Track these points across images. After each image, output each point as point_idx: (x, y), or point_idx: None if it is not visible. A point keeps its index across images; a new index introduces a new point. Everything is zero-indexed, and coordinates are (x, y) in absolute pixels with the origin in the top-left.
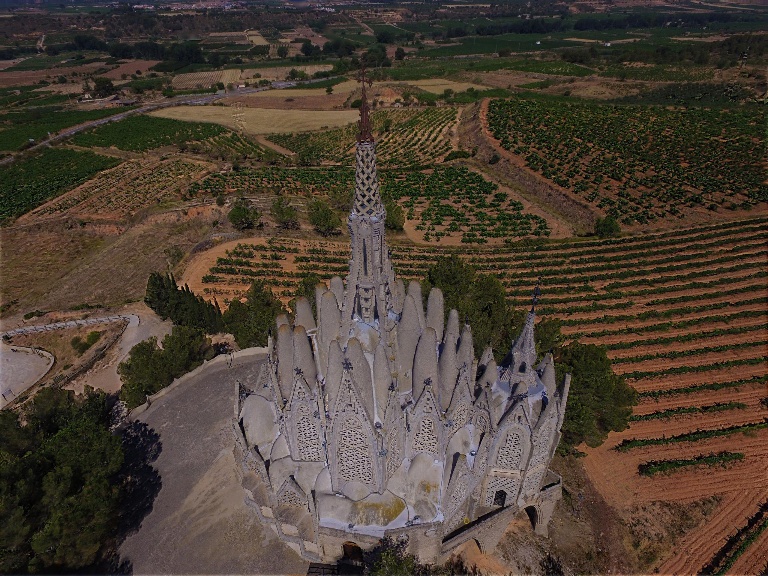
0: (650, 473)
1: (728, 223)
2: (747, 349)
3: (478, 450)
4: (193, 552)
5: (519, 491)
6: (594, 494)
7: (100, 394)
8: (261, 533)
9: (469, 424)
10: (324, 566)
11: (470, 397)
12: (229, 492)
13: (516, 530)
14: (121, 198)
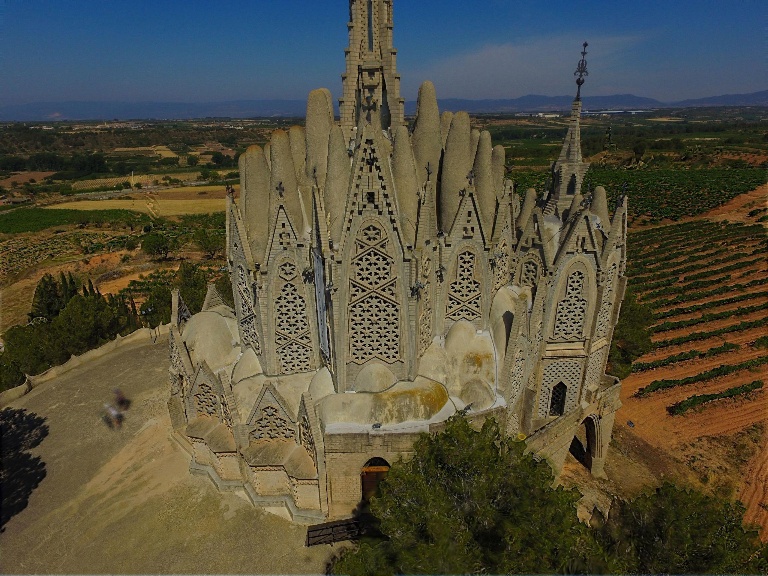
0: (683, 409)
1: (647, 230)
2: (712, 309)
3: (533, 305)
4: (102, 548)
5: (583, 379)
6: (634, 438)
7: None
8: (221, 503)
9: (510, 286)
10: (332, 524)
11: (511, 237)
12: (162, 464)
13: (569, 474)
14: (2, 263)
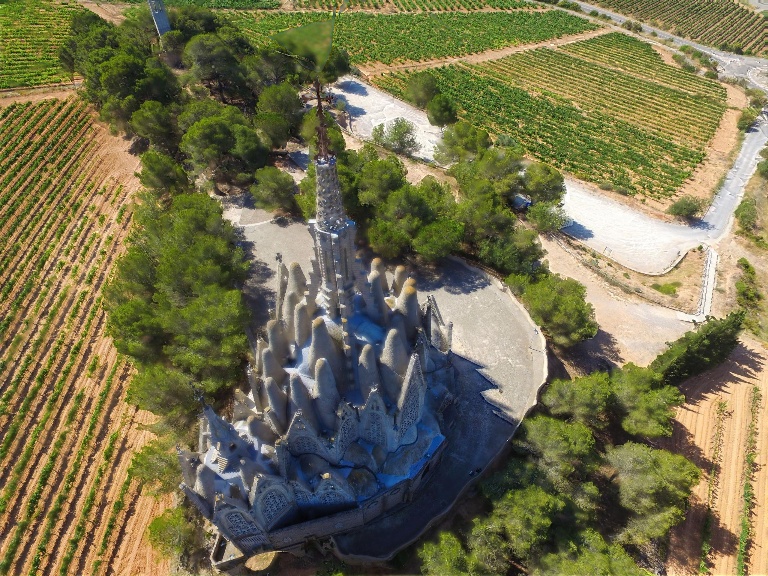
0: None
1: None
2: None
3: None
4: None
5: None
6: None
7: (545, 274)
8: None
9: None
10: None
11: None
12: None
13: None
14: None
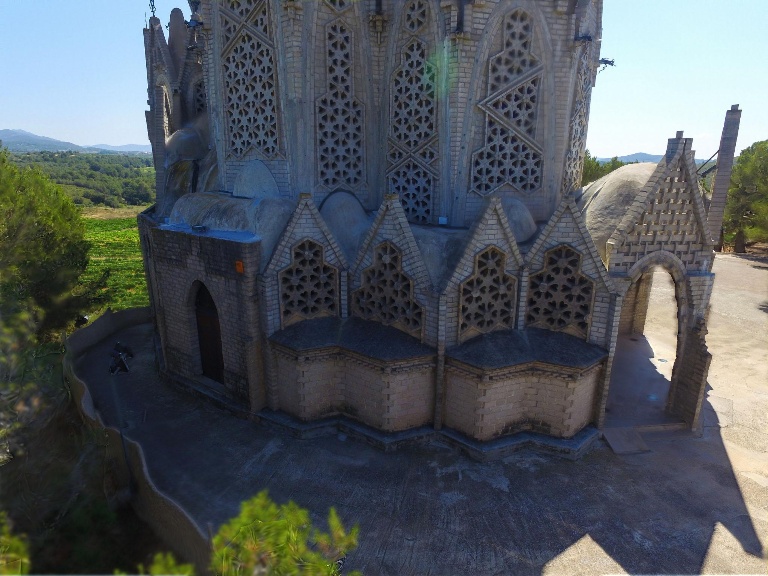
0: None
1: None
2: None
3: None
4: None
5: None
6: None
7: None
8: None
9: None
10: None
11: None
12: None
13: None
14: None
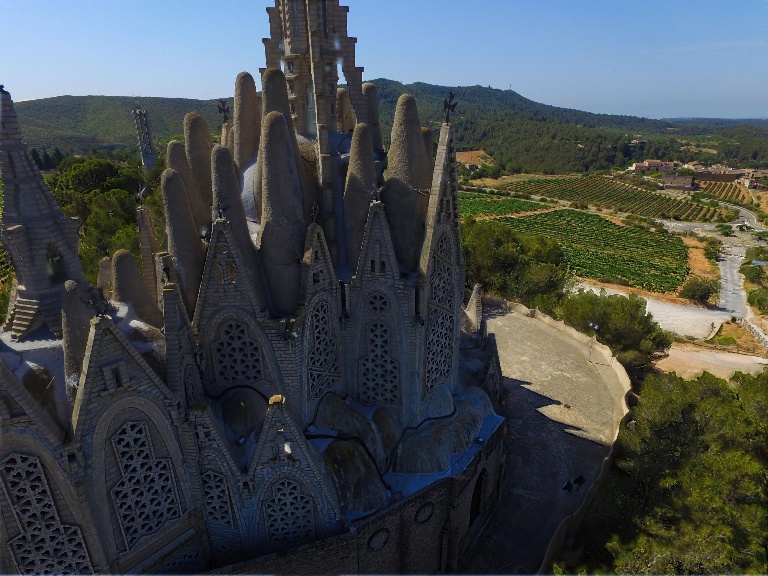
0: None
1: None
2: None
3: None
4: None
5: None
6: None
7: None
8: None
9: None
10: None
11: None
12: None
13: None
14: None
